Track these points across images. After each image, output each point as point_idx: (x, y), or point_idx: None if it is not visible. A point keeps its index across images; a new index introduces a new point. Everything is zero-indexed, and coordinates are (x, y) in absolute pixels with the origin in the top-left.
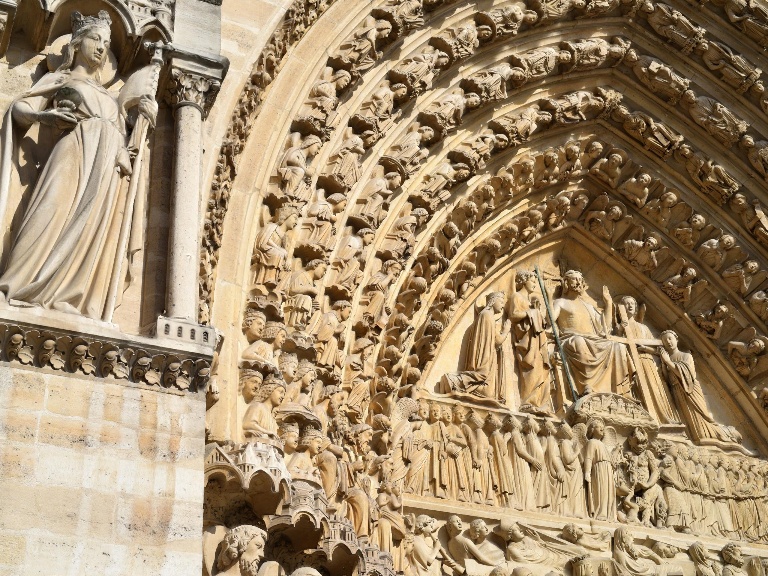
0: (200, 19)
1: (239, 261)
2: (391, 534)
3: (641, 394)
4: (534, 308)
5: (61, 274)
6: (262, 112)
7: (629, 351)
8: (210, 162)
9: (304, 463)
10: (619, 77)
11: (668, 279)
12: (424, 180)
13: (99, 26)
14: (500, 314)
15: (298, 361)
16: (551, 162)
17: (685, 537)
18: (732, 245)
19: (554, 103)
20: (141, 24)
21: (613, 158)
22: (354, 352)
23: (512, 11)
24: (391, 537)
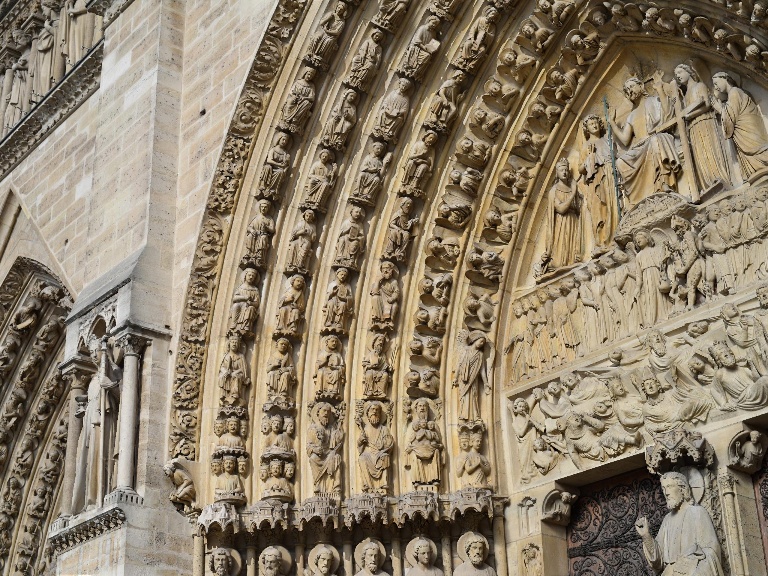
0: None
1: None
2: (416, 461)
3: None
4: None
5: (86, 493)
6: (222, 277)
7: None
8: None
9: (270, 485)
10: None
11: None
12: None
13: None
14: None
15: None
16: (527, 35)
17: (724, 301)
18: None
19: None
20: (108, 324)
21: None
22: (373, 348)
23: (383, 1)
24: (416, 463)
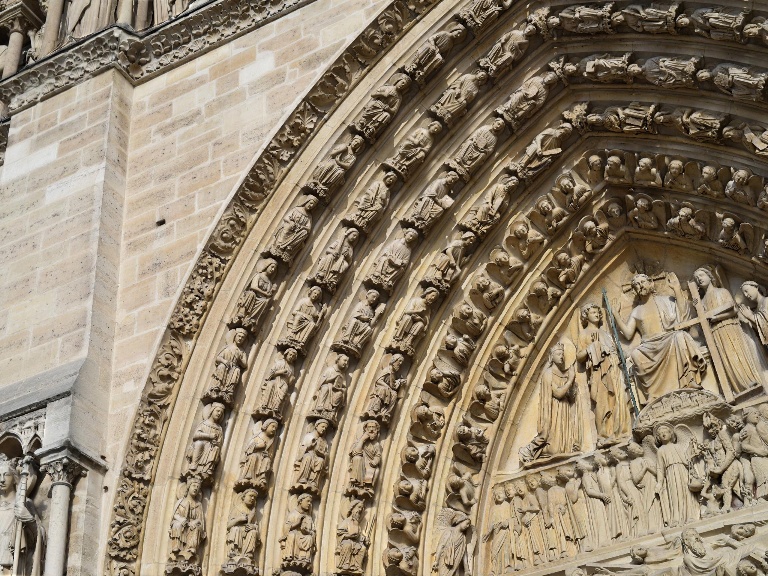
0: (59, 415)
1: (157, 543)
2: None
3: (716, 371)
4: (593, 341)
5: None
6: (175, 410)
7: (702, 329)
8: (113, 492)
9: None
10: (579, 89)
11: None
12: (396, 327)
13: None
14: (573, 359)
15: None
16: (544, 211)
17: None
18: (745, 179)
19: (513, 166)
20: (27, 444)
21: (608, 164)
22: (348, 516)
23: (404, 145)
24: None
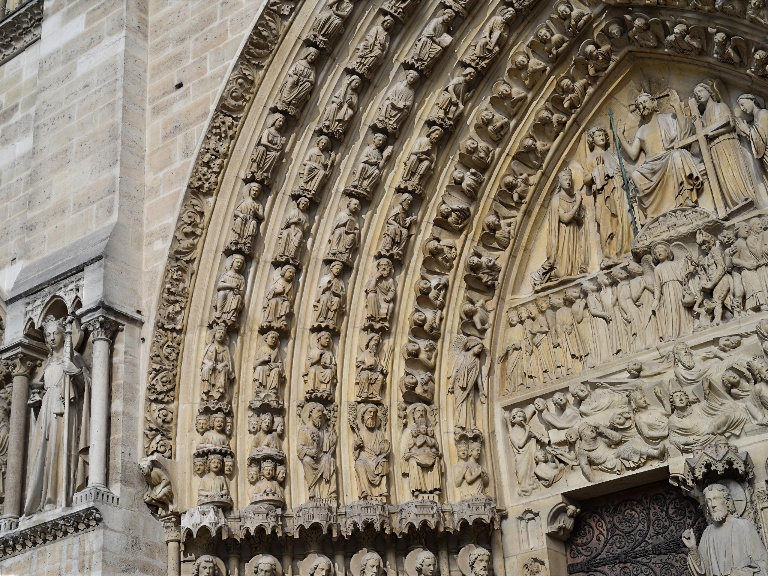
0: (94, 277)
1: None
2: (416, 468)
3: None
4: None
5: (43, 491)
6: (202, 263)
7: None
8: None
9: (261, 488)
10: None
11: None
12: (404, 167)
13: (48, 327)
14: (582, 183)
15: (259, 416)
16: (543, 39)
17: (756, 317)
18: None
19: None
20: (70, 305)
21: None
22: (366, 349)
23: None
24: (416, 470)
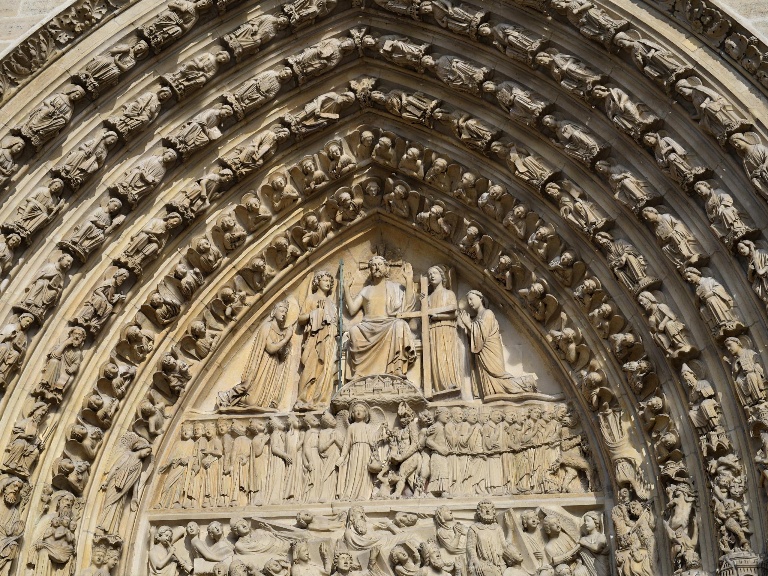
0: None
1: None
2: (46, 561)
3: None
4: (318, 308)
5: None
6: None
7: None
8: None
9: None
10: (372, 63)
11: (459, 242)
12: (130, 241)
13: None
14: (295, 319)
15: None
16: (306, 170)
17: (437, 502)
18: (499, 195)
19: (289, 118)
20: None
21: (379, 143)
22: (29, 416)
23: (188, 64)
24: (46, 564)
